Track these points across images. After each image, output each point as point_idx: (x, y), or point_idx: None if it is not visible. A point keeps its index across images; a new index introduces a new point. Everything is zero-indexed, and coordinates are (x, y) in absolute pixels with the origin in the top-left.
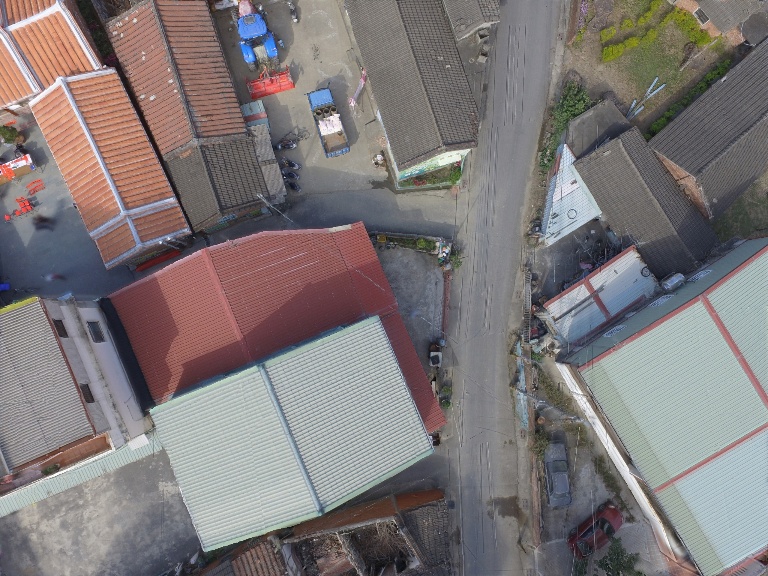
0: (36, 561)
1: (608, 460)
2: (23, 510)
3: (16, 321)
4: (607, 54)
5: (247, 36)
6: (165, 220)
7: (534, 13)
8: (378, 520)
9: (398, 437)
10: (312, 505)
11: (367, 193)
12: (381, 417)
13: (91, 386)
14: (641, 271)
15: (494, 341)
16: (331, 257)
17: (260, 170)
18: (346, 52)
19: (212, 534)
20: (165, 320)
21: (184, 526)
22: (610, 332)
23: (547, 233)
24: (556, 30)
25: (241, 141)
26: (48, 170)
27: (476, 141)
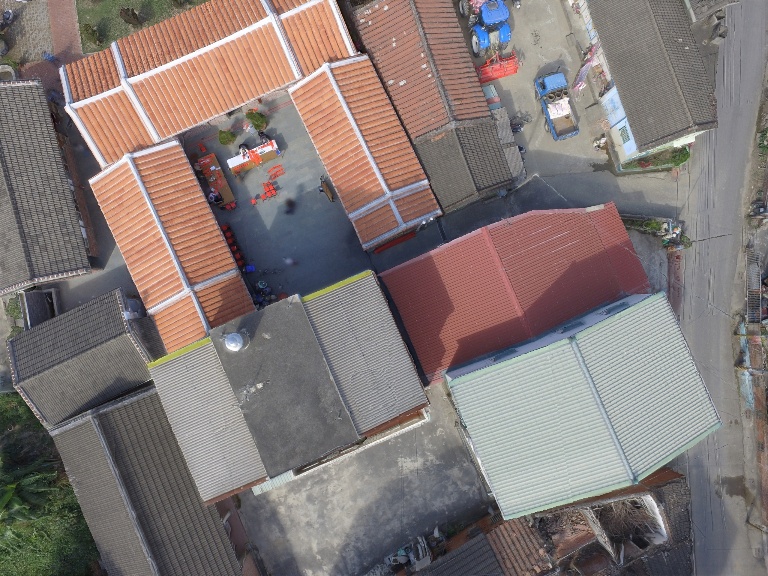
0: (285, 533)
1: None
2: None
3: (354, 293)
4: None
5: (491, 21)
6: (420, 201)
7: None
8: (632, 495)
9: (690, 410)
10: (624, 474)
11: (589, 176)
12: (675, 390)
13: None
14: None
15: (718, 322)
16: (590, 236)
17: (503, 152)
18: (565, 37)
19: (514, 503)
20: (439, 297)
21: (423, 501)
22: None
23: None
24: None
25: (486, 124)
26: (288, 155)
27: (717, 122)
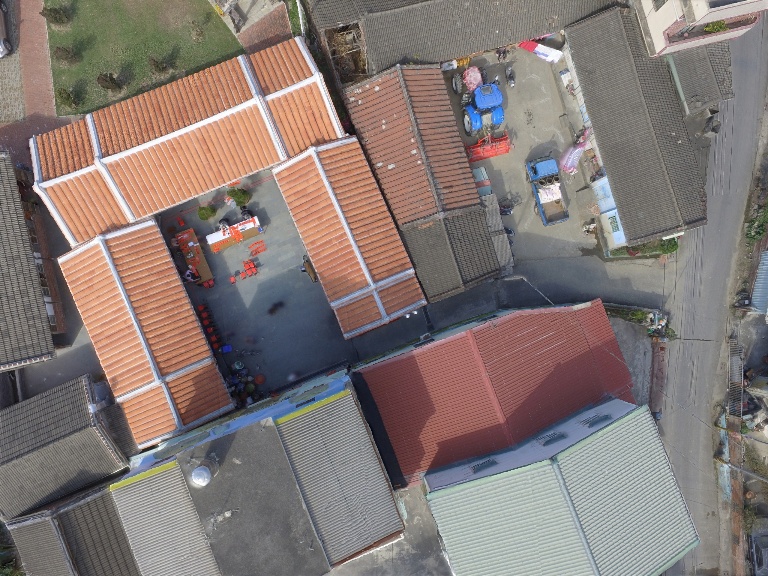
0: None
1: None
2: None
3: (331, 414)
4: None
5: (484, 106)
6: (404, 291)
7: (743, 83)
8: None
9: (669, 528)
10: None
11: (577, 260)
12: (655, 508)
13: None
14: None
15: (699, 412)
16: (576, 336)
17: (491, 241)
18: (558, 118)
19: None
20: (421, 398)
21: None
22: None
23: None
24: (763, 100)
25: (475, 212)
26: (270, 231)
27: (706, 218)
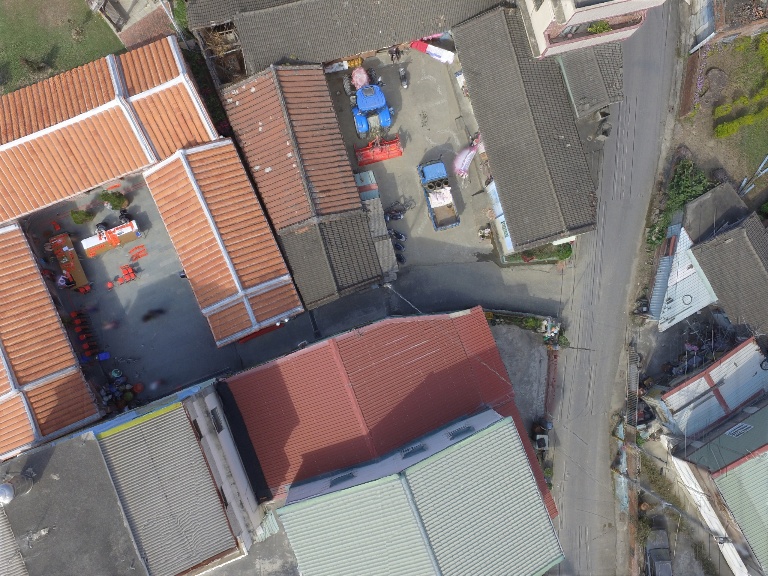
0: None
1: (709, 548)
2: None
3: (160, 428)
4: (722, 132)
5: (365, 108)
6: (279, 298)
7: (645, 85)
8: None
9: (531, 544)
10: None
11: (472, 266)
12: (515, 524)
13: (224, 487)
14: (761, 364)
15: (596, 422)
16: (452, 344)
17: (374, 246)
18: (454, 120)
19: None
20: (285, 408)
21: None
22: (734, 431)
23: (661, 318)
24: (667, 103)
25: (356, 216)
26: (151, 235)
27: (595, 223)
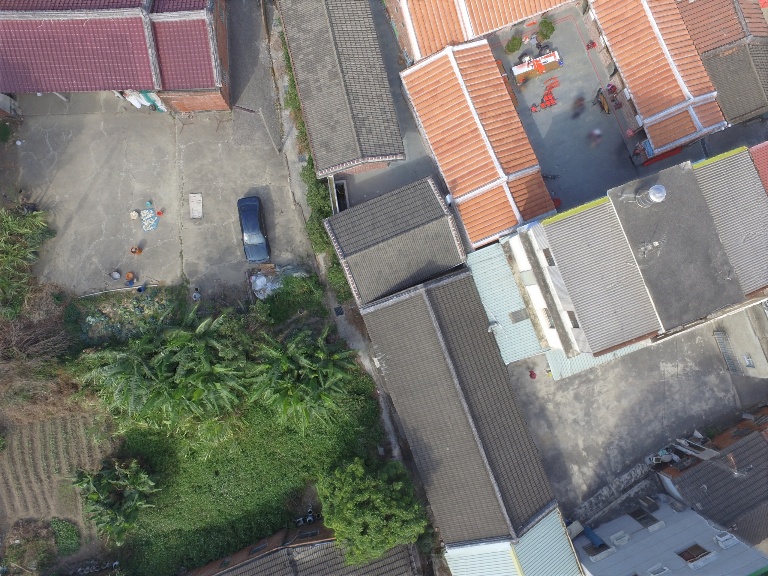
0: (553, 429)
1: None
2: (541, 381)
3: (733, 166)
4: None
5: None
6: (710, 112)
7: None
8: None
9: None
10: None
11: None
12: None
13: None
14: None
15: None
16: None
17: None
18: None
19: None
20: None
21: (683, 405)
22: None
23: None
24: None
25: (766, 45)
26: (563, 69)
27: None
